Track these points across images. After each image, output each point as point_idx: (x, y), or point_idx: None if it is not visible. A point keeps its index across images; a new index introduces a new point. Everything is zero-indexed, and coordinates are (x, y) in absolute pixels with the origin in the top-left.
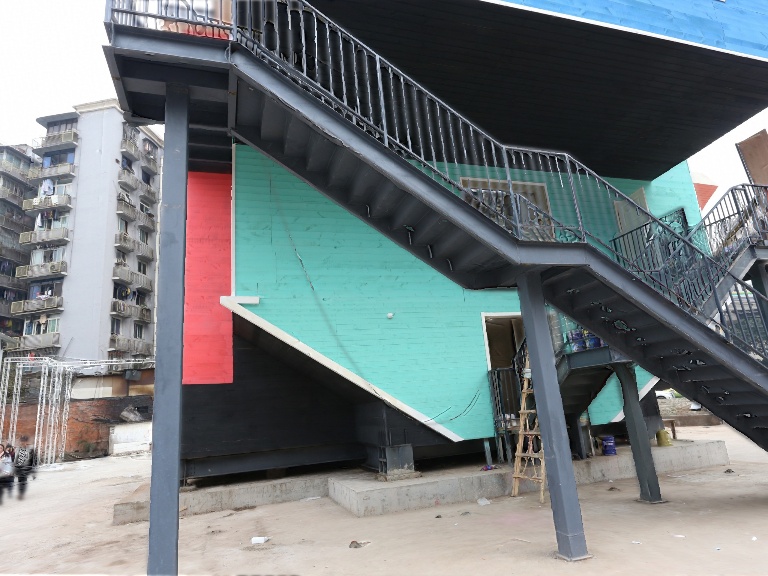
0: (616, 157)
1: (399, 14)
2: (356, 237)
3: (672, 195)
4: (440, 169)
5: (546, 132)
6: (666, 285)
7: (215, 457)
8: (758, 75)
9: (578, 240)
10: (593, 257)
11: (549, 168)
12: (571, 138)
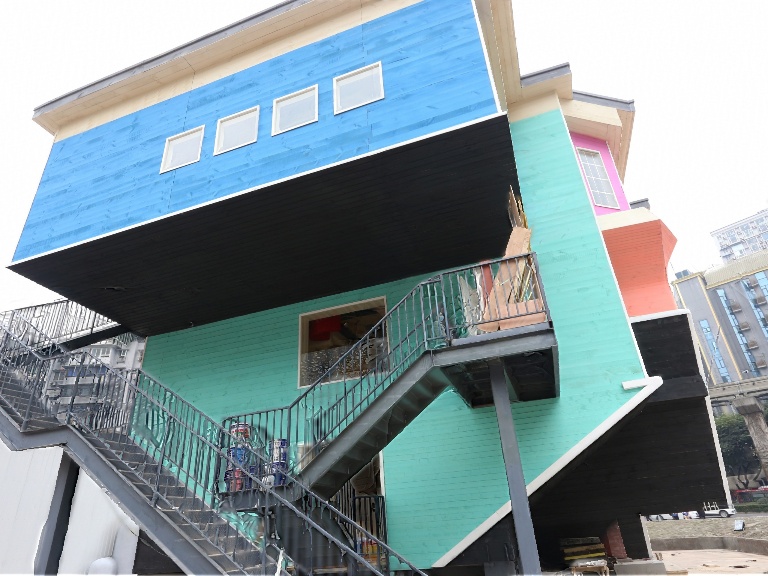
0: (435, 251)
1: (106, 254)
2: (209, 390)
3: (563, 258)
4: (283, 312)
5: (324, 262)
6: (296, 421)
7: (164, 574)
8: (433, 151)
9: (175, 399)
10: (74, 435)
11: (385, 280)
12: (355, 257)
